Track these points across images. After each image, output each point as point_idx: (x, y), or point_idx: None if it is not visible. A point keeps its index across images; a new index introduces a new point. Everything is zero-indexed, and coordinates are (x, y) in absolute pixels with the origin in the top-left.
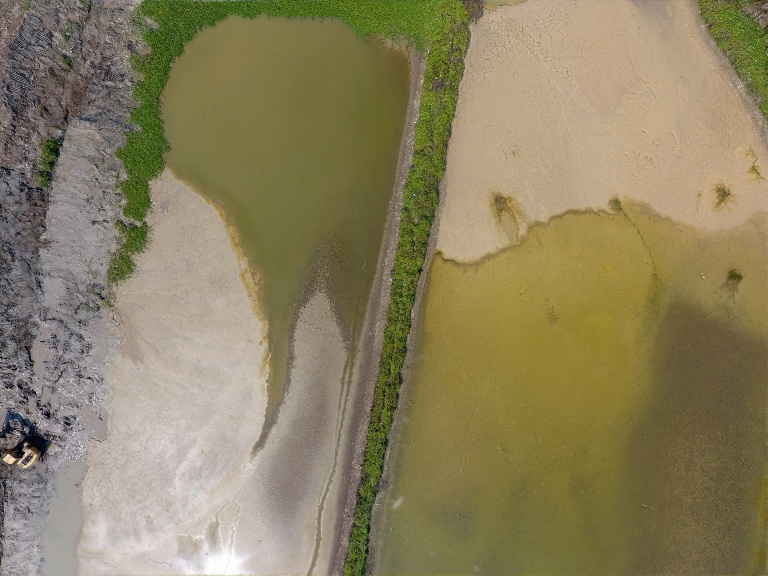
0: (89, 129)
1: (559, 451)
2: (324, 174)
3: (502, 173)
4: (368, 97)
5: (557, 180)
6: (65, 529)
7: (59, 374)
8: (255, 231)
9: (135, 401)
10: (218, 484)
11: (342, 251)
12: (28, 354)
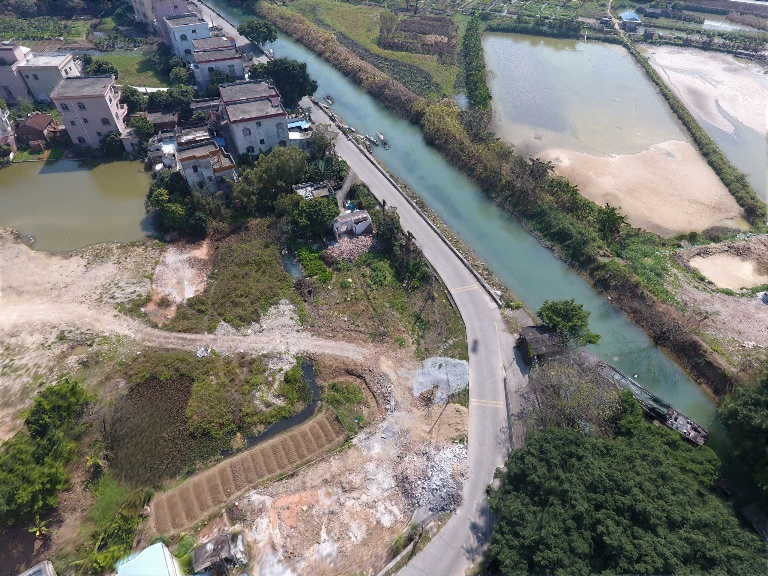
0: None
1: None
2: (766, 163)
3: None
4: None
5: None
6: None
7: None
8: None
9: None
10: None
11: None
12: None
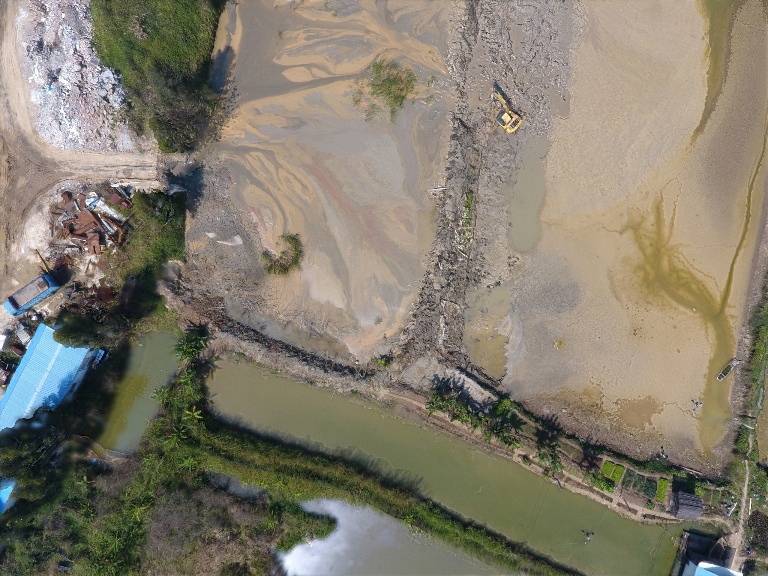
0: None
1: None
2: None
3: None
4: None
5: None
6: (529, 198)
7: (532, 55)
8: None
9: (595, 84)
10: (663, 163)
11: None
12: (508, 34)
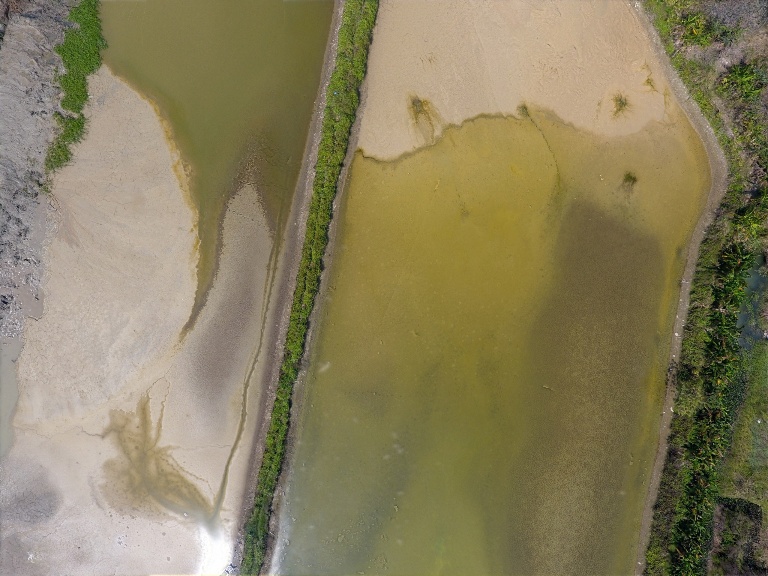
0: (29, 25)
1: (469, 335)
2: (253, 75)
3: (419, 78)
4: (295, 5)
5: (470, 86)
6: (1, 403)
7: None
8: (187, 126)
9: (70, 282)
10: (149, 362)
11: (269, 147)
12: None
